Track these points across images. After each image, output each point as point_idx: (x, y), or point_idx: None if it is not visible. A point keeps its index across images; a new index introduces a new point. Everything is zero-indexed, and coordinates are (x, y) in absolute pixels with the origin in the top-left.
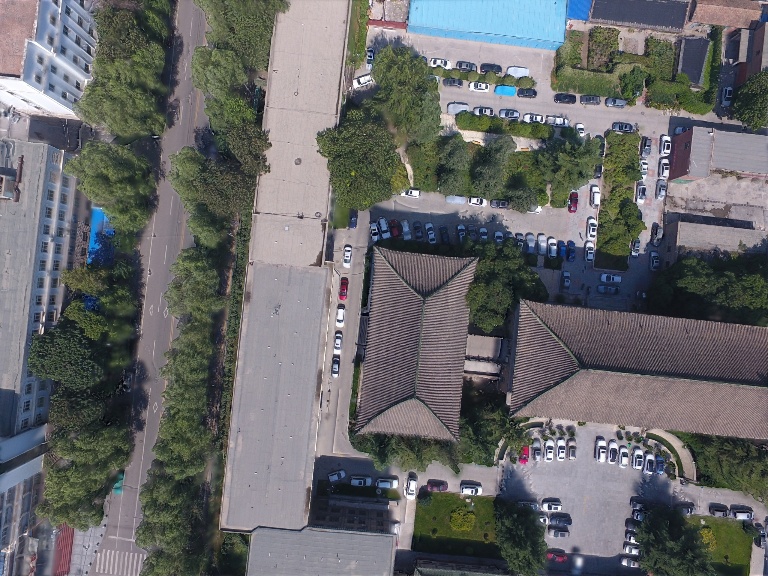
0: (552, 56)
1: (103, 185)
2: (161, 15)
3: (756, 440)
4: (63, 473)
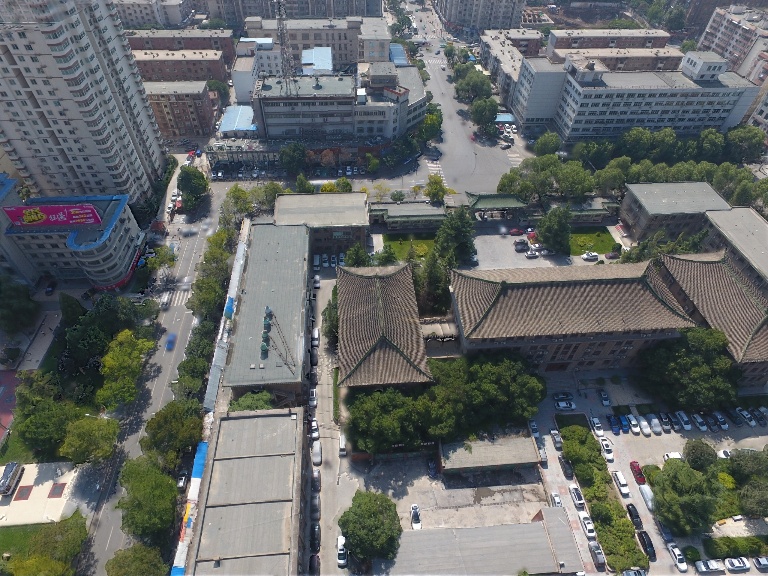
0: None
1: None
2: None
3: (427, 292)
4: None
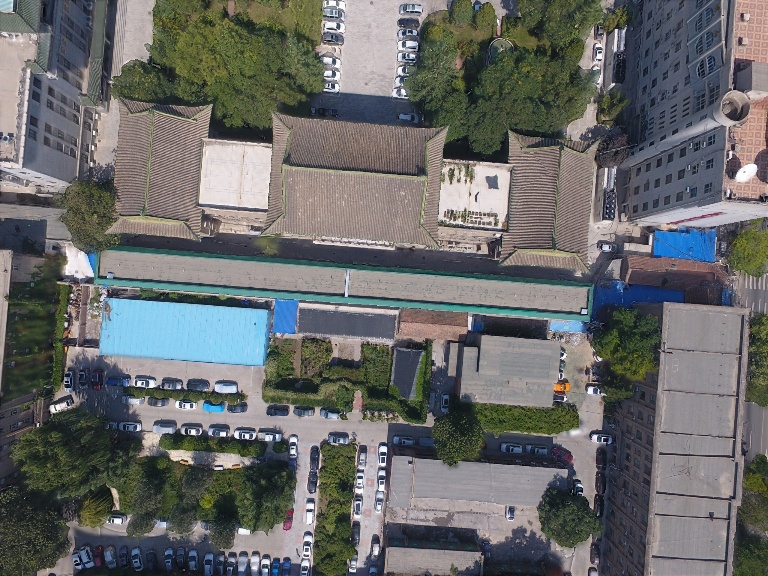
0: (262, 368)
1: None
2: None
3: None
4: None
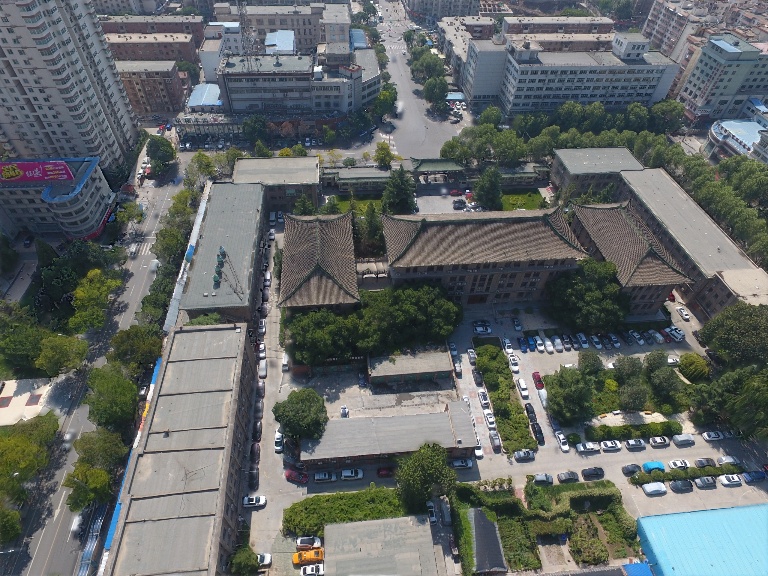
0: None
1: None
2: None
3: None
4: (761, 169)
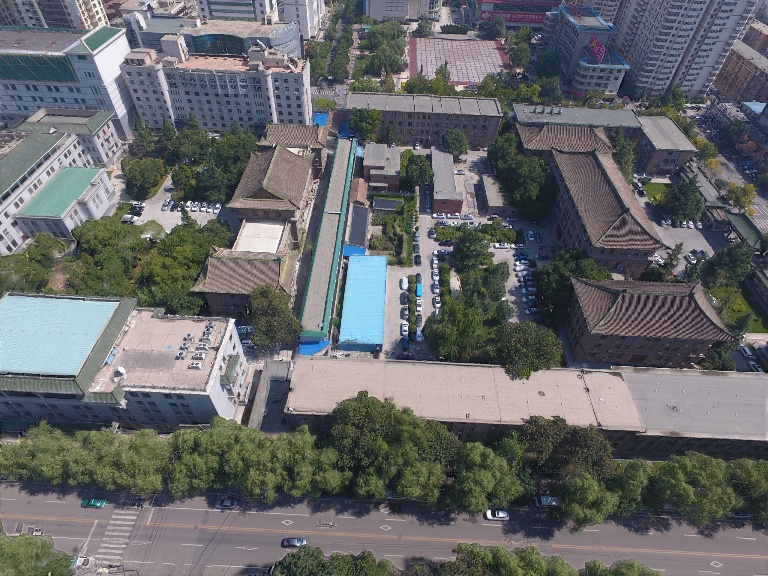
0: (390, 267)
1: (649, 574)
2: (404, 571)
3: None
4: None
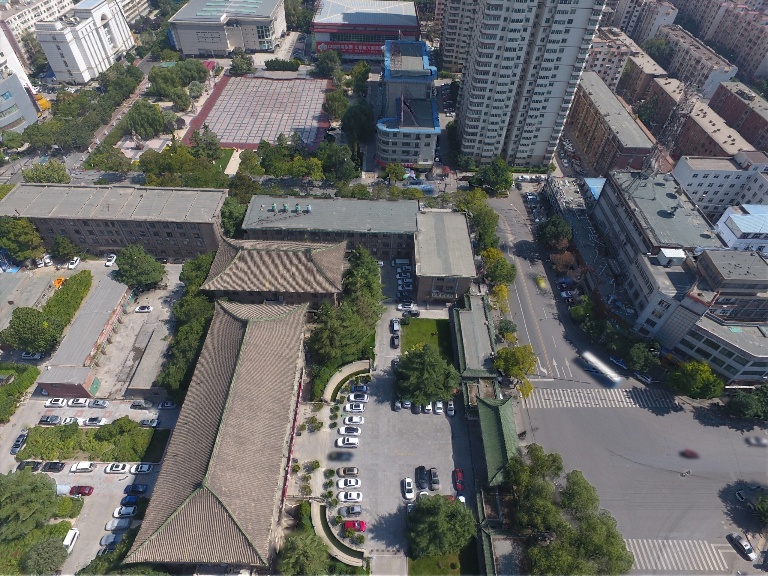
0: None
1: None
2: None
3: None
4: None
